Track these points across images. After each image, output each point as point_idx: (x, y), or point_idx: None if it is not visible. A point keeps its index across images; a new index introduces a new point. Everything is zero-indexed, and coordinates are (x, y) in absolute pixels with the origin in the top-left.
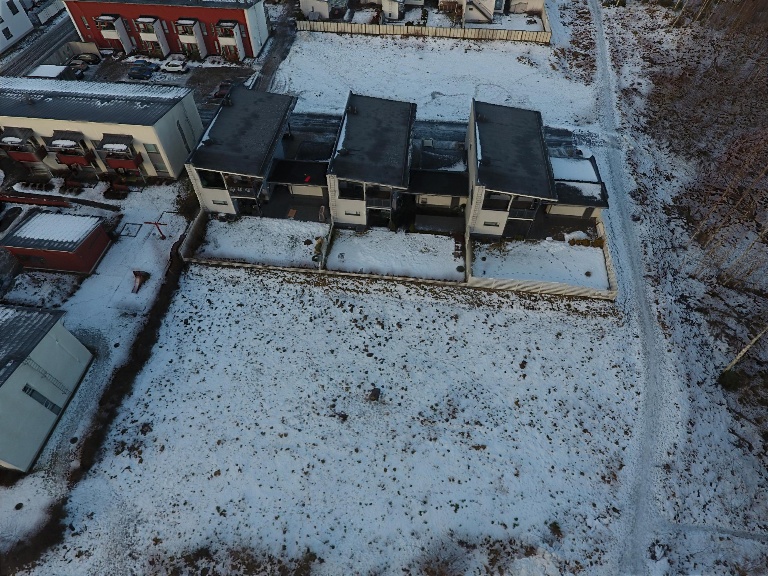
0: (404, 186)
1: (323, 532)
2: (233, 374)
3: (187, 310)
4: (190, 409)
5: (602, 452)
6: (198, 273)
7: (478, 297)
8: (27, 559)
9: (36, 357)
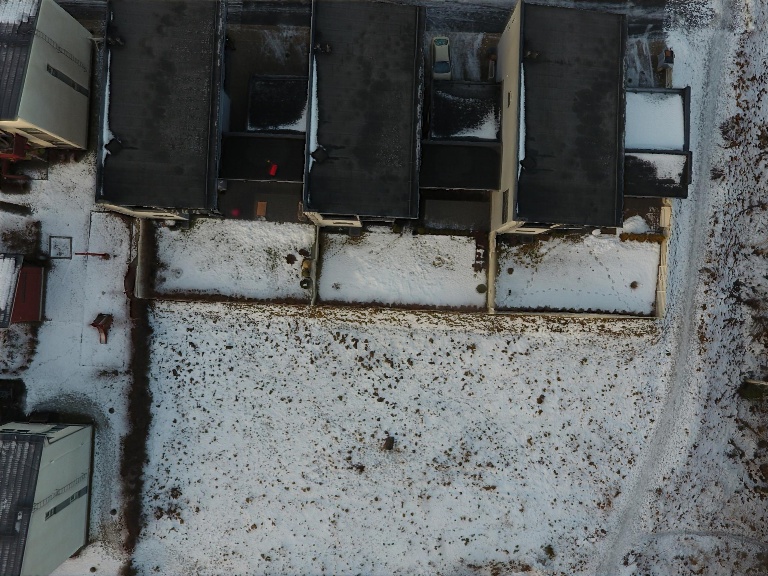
0: (413, 216)
1: (355, 568)
2: (243, 431)
3: (171, 358)
4: (211, 471)
5: (603, 482)
6: (168, 310)
7: (500, 323)
8: None
9: (41, 493)
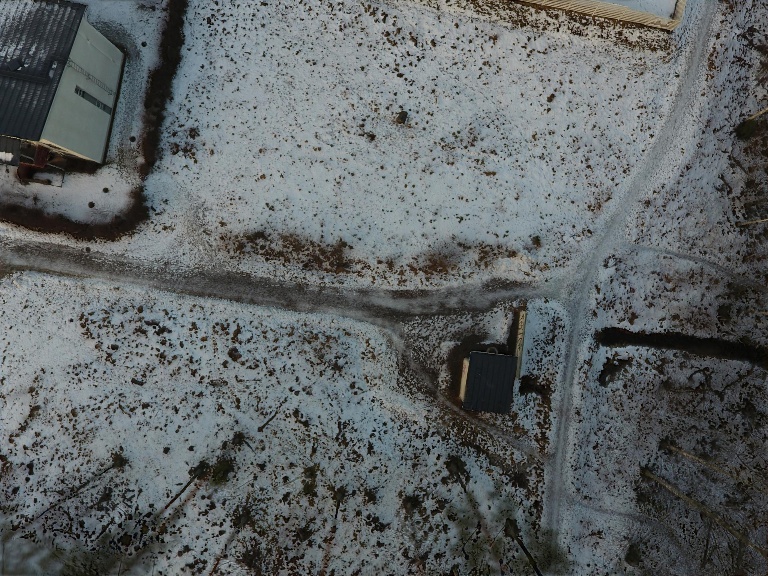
0: None
1: (352, 228)
2: (265, 85)
3: (207, 6)
4: (230, 118)
5: (596, 186)
6: None
7: (524, 15)
8: (126, 228)
9: (75, 58)
